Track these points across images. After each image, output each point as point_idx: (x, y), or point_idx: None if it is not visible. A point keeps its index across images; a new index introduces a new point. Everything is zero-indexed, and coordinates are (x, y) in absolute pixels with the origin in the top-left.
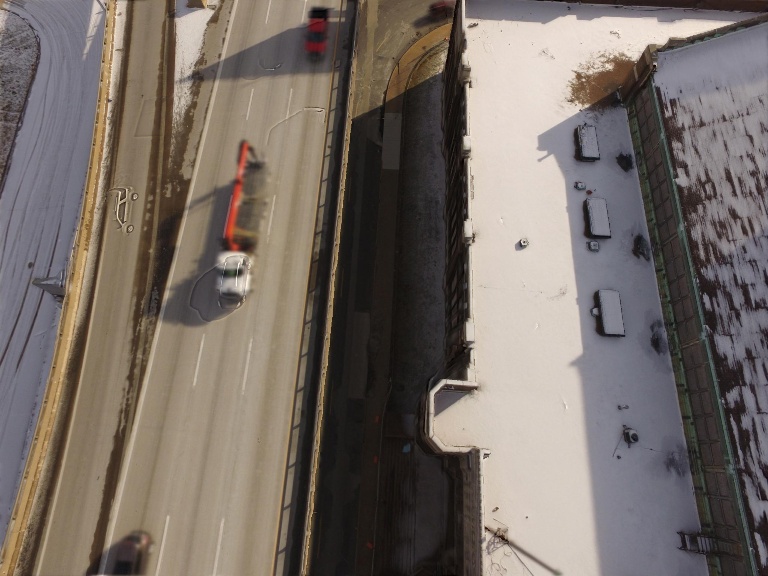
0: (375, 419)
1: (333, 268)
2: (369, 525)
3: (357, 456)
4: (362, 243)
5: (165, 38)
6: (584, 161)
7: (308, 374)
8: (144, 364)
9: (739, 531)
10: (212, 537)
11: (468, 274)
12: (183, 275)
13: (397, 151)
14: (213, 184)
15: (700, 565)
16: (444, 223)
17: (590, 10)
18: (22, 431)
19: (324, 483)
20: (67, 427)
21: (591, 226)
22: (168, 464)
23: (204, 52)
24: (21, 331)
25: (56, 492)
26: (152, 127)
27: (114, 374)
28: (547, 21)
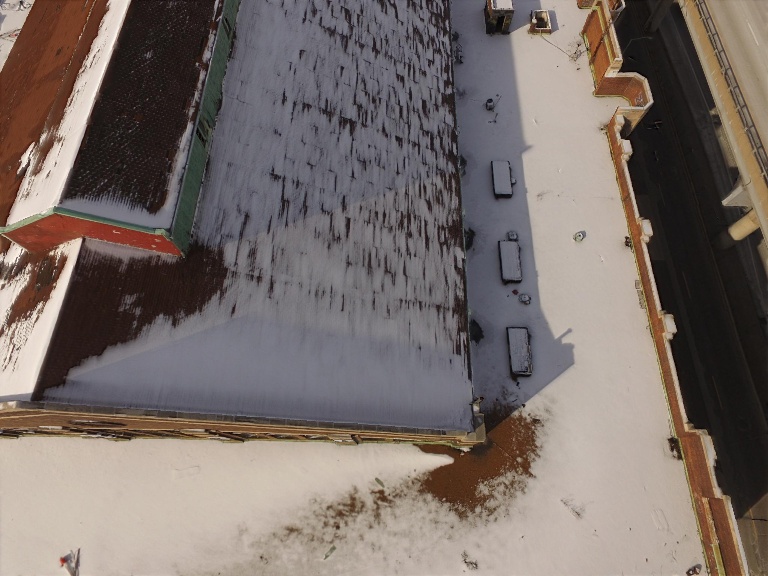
0: None
1: (764, 179)
2: None
3: None
4: (681, 327)
5: None
6: None
7: None
8: None
9: None
10: (760, 37)
11: None
12: None
13: None
14: None
15: None
16: None
17: None
18: None
19: (647, 144)
20: None
21: None
22: None
23: None
24: None
25: None
26: None
27: None
28: None
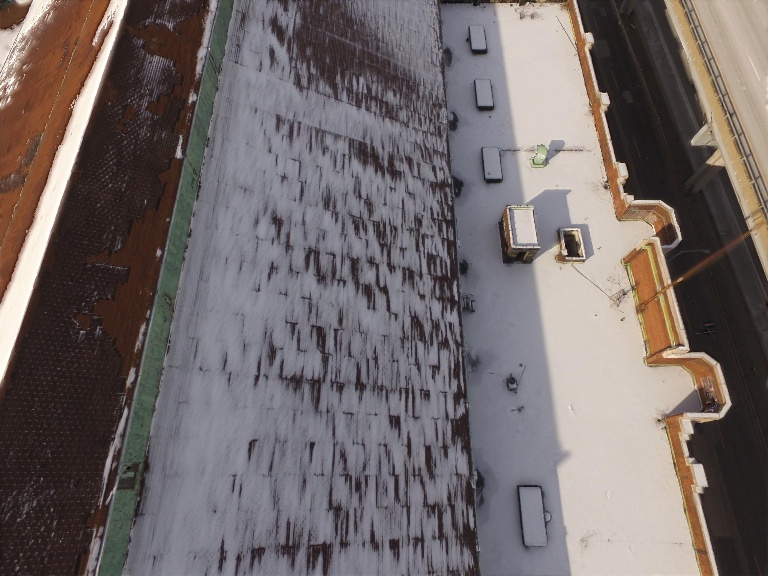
0: None
1: None
2: None
3: None
4: None
5: None
6: None
7: None
8: None
9: None
10: None
11: None
12: None
13: None
14: None
15: None
16: None
17: None
18: None
19: None
20: None
21: None
22: None
23: None
24: None
25: None
26: None
27: None
28: None
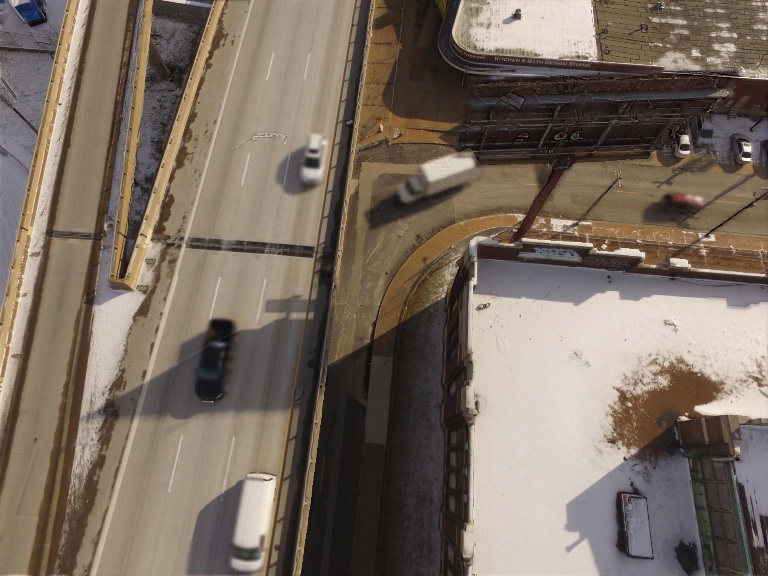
0: None
1: None
2: None
3: None
4: (333, 560)
5: (77, 340)
6: (631, 557)
7: None
8: None
9: None
10: None
11: None
12: None
13: (385, 416)
14: None
15: None
16: (439, 535)
17: (637, 283)
18: None
19: None
20: None
21: None
22: None
23: (124, 367)
24: None
25: None
26: (41, 499)
27: None
28: (581, 301)
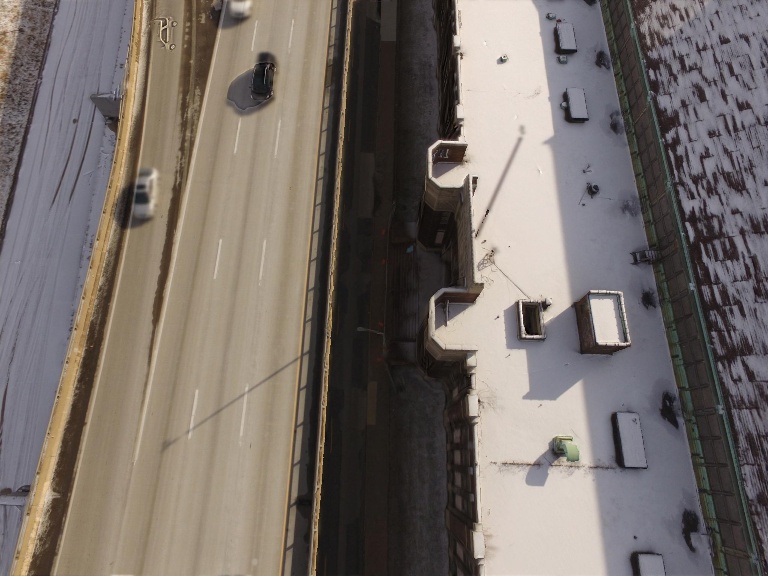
0: (382, 232)
1: (345, 66)
2: (380, 308)
3: (368, 260)
4: (365, 99)
5: None
6: None
7: (328, 143)
8: (192, 140)
9: (675, 229)
10: (257, 252)
11: (457, 75)
12: (220, 77)
13: (394, 26)
14: (240, 13)
15: (648, 274)
16: (437, 81)
17: None
18: (78, 247)
19: (340, 280)
20: (133, 184)
21: (560, 43)
22: (218, 206)
23: None
24: (71, 172)
25: (128, 227)
26: None
27: (168, 147)
28: None
